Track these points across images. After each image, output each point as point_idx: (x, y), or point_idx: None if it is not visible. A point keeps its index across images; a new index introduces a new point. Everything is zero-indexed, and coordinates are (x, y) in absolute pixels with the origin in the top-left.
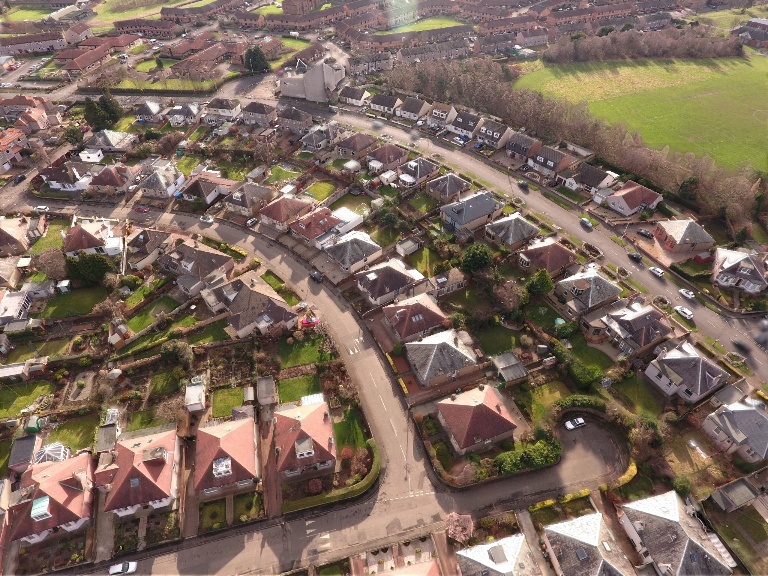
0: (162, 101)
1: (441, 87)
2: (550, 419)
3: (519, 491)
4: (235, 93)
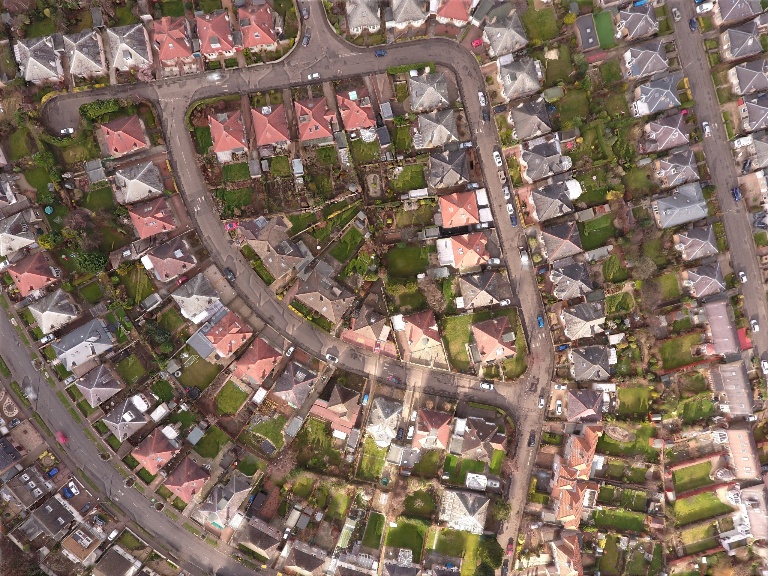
0: None
1: None
2: (80, 128)
3: (113, 96)
4: None
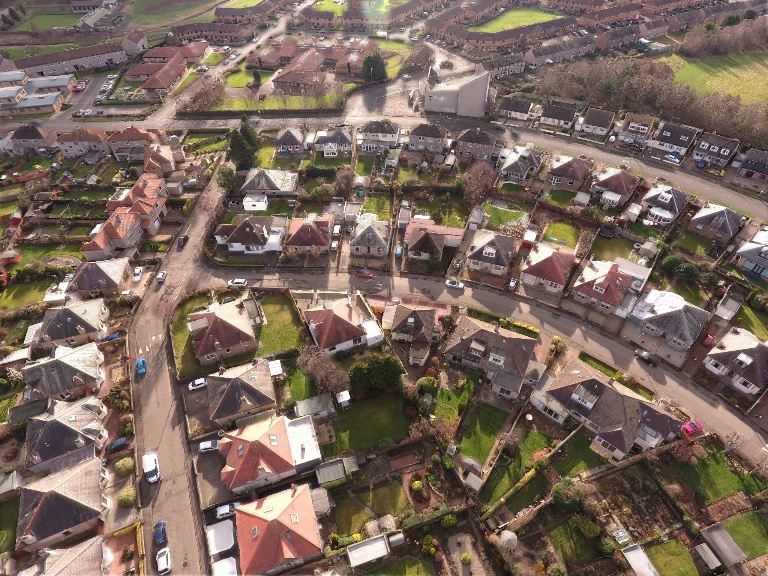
0: (291, 125)
1: (609, 93)
2: None
3: None
4: (368, 110)
